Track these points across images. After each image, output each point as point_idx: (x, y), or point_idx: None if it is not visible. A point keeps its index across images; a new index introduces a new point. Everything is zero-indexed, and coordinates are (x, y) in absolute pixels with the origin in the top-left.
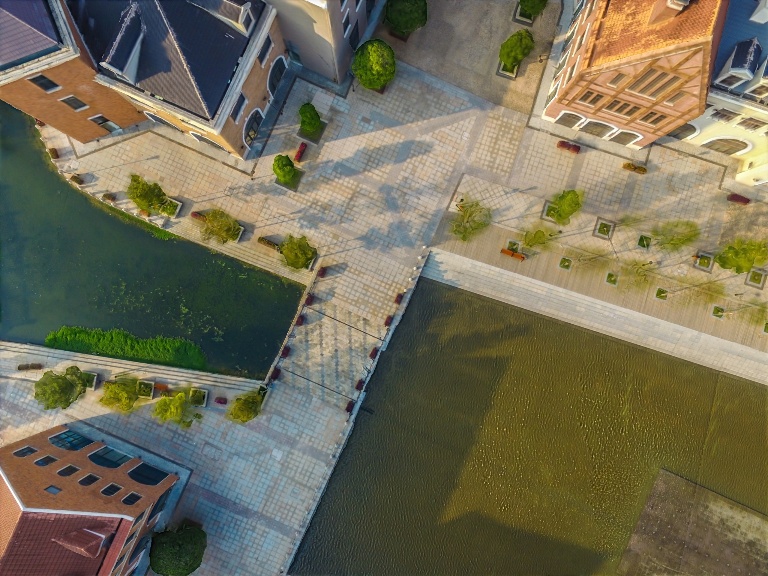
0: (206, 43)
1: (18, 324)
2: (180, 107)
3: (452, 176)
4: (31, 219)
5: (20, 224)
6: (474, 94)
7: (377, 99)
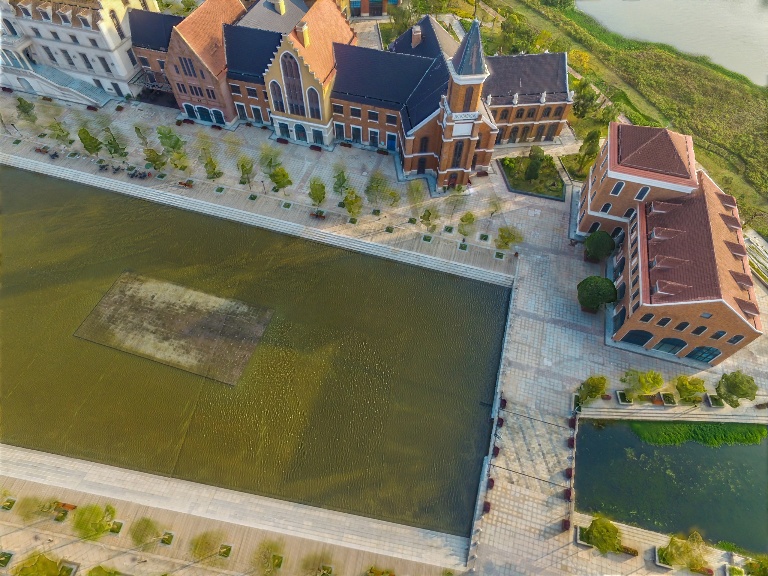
0: None
1: None
2: None
3: None
4: None
5: None
6: None
7: None
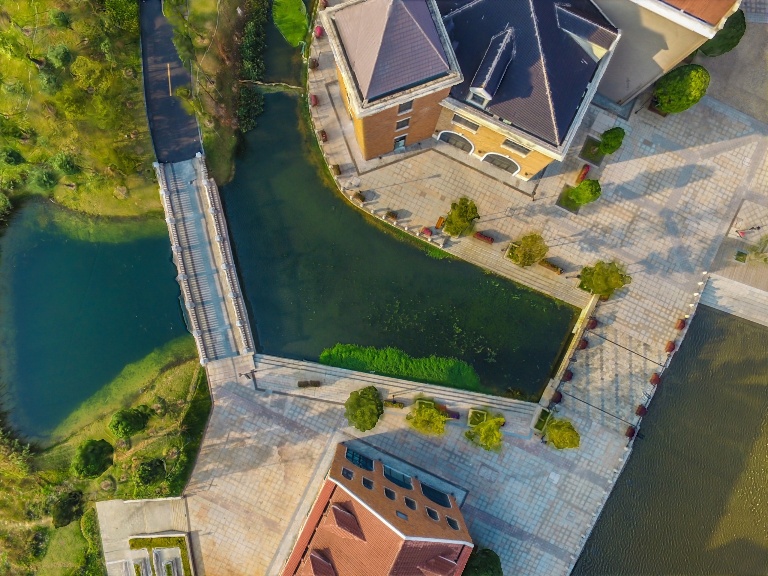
0: (566, 69)
1: (292, 340)
2: (528, 132)
3: (732, 202)
4: (306, 235)
5: (295, 240)
6: (756, 119)
7: (659, 122)
